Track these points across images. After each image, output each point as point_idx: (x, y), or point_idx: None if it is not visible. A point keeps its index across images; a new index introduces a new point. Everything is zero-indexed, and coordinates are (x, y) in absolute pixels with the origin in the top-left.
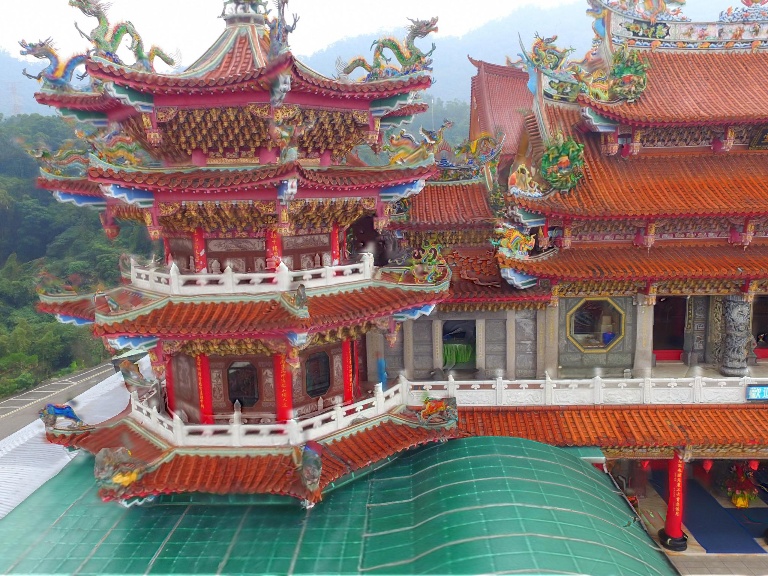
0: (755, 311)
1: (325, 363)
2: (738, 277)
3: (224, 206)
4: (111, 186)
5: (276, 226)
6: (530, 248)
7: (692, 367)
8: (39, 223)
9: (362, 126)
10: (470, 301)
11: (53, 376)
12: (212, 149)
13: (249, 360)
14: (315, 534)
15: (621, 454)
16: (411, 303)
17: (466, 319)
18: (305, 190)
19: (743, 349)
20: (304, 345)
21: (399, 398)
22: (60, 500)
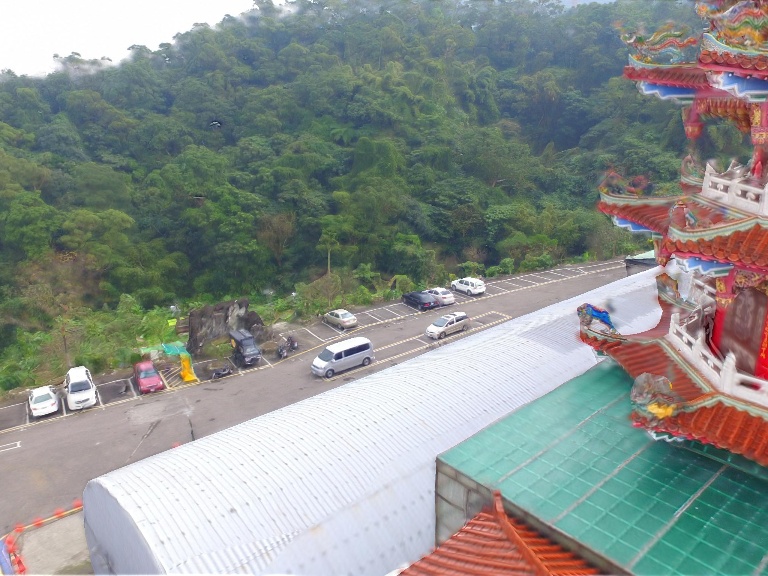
0: None
1: None
2: None
3: None
4: (721, 74)
5: None
6: None
7: None
8: (577, 114)
9: None
10: None
11: (566, 261)
12: None
13: None
14: None
15: None
16: None
17: None
18: None
19: None
20: None
21: None
22: (586, 402)
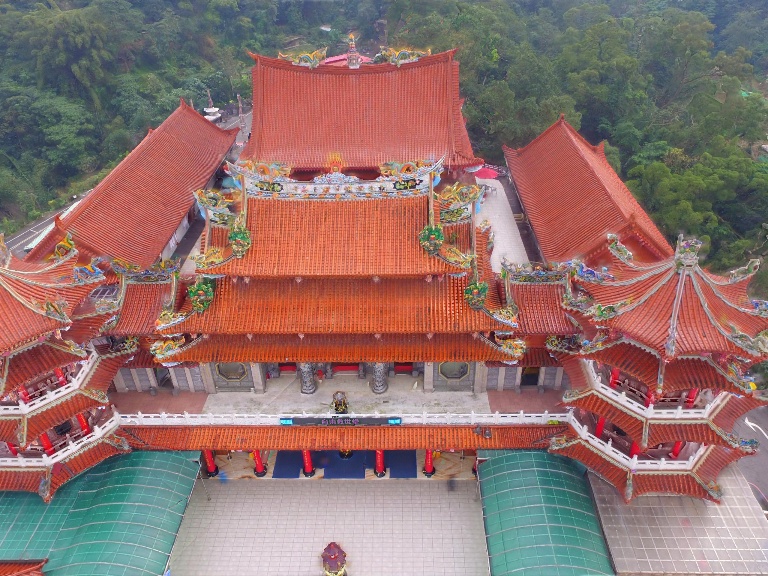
0: None
1: None
2: None
3: None
4: None
5: None
6: (182, 344)
7: (296, 380)
8: None
9: None
10: None
11: None
12: None
13: None
14: (52, 510)
15: None
16: None
17: None
18: None
19: (308, 382)
20: None
21: (115, 422)
22: None
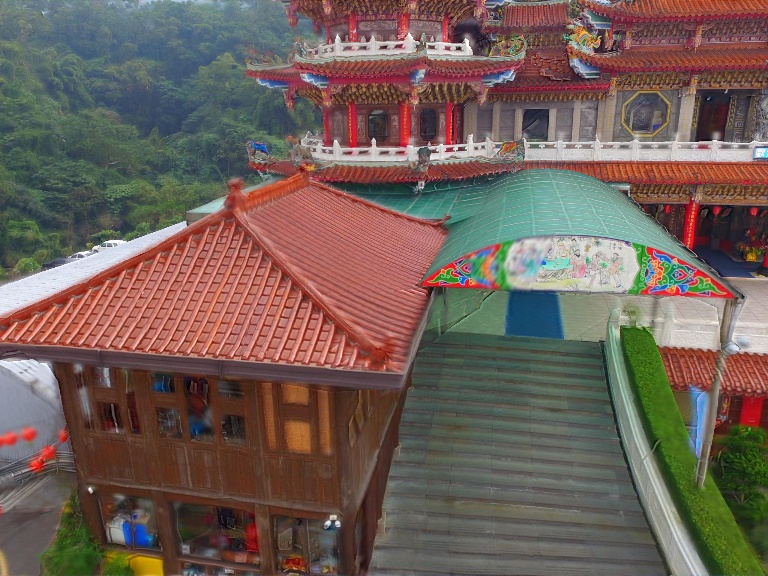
0: None
1: (434, 118)
2: (765, 67)
3: None
4: None
5: (406, 9)
6: (596, 46)
7: None
8: (174, 103)
9: None
10: (545, 89)
11: None
12: None
13: (383, 108)
14: (424, 201)
15: (648, 199)
16: (497, 67)
17: (542, 108)
18: None
19: (767, 134)
20: (422, 90)
21: (485, 153)
22: None
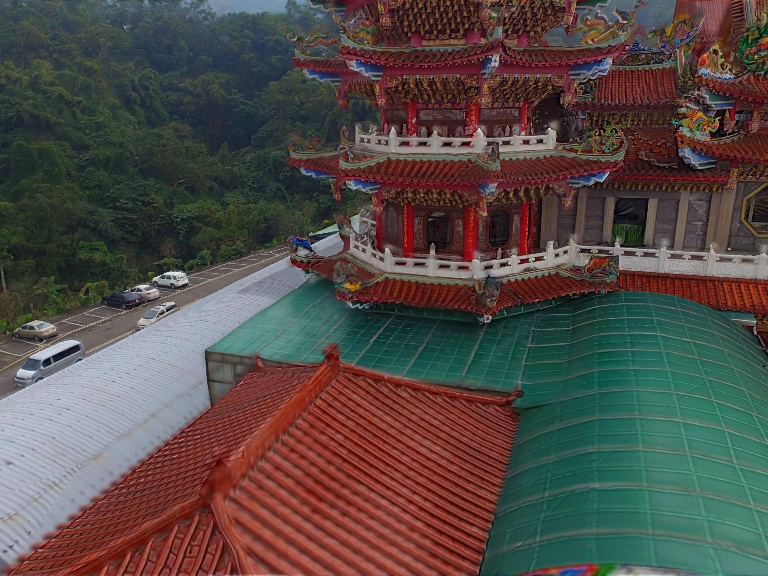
0: None
1: (506, 220)
2: None
3: (437, 79)
4: (354, 61)
5: (476, 98)
6: (713, 130)
7: None
8: (245, 116)
9: (559, 8)
10: (645, 179)
11: None
12: (428, 32)
13: (445, 211)
14: (490, 340)
15: None
16: (587, 170)
17: (639, 197)
18: (504, 66)
19: None
20: (492, 198)
21: (567, 258)
22: (304, 302)
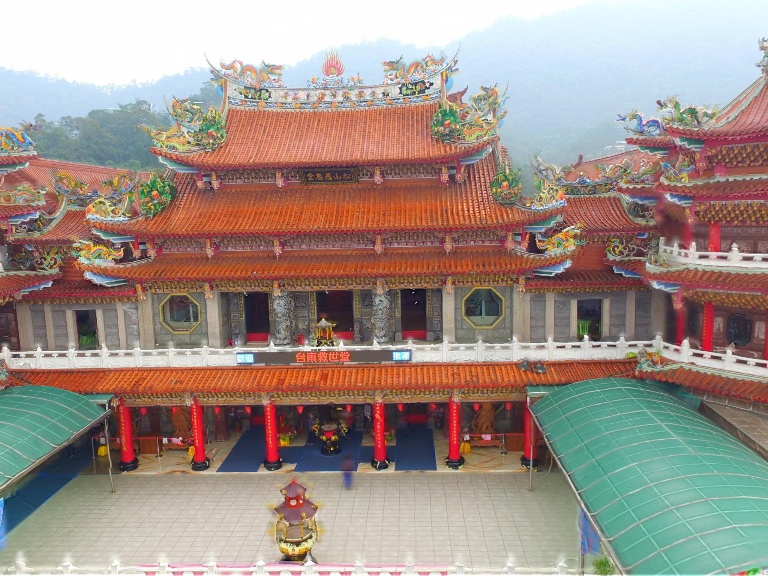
0: (318, 304)
1: None
2: (255, 278)
3: None
4: None
5: None
6: (118, 257)
7: (268, 345)
8: None
9: None
10: None
11: None
12: None
13: None
14: None
15: (154, 402)
16: None
17: (89, 309)
18: None
19: (282, 331)
20: None
21: None
22: None
